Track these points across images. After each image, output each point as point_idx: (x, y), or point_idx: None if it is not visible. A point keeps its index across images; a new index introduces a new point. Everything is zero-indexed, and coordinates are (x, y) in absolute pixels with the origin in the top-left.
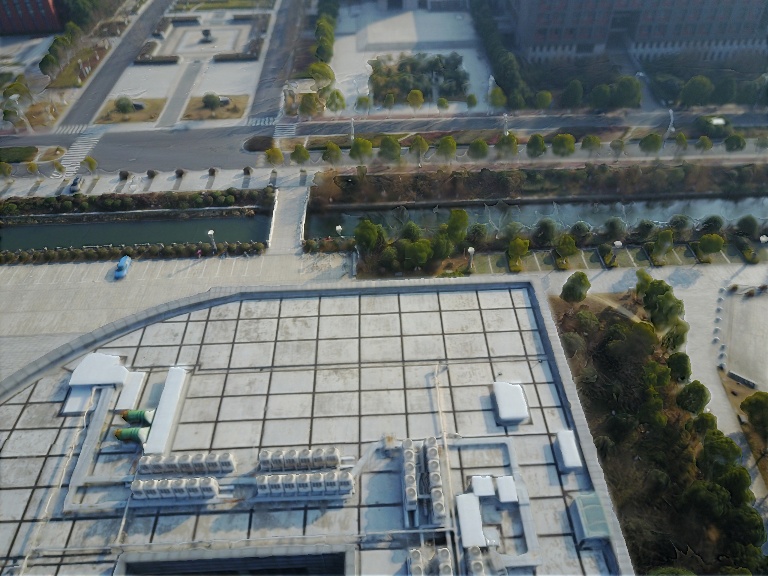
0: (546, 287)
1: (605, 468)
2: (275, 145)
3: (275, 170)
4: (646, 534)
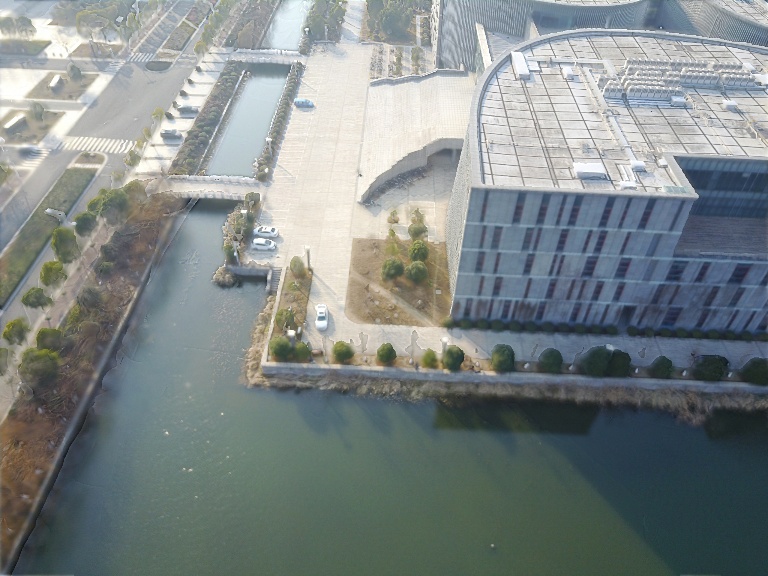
0: (358, 6)
1: None
2: (163, 61)
3: (203, 61)
4: None
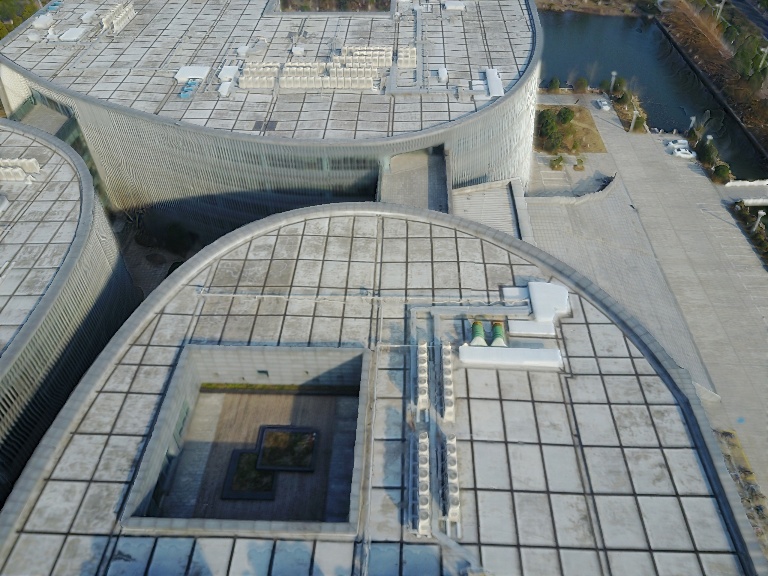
0: None
1: None
2: None
3: None
4: None
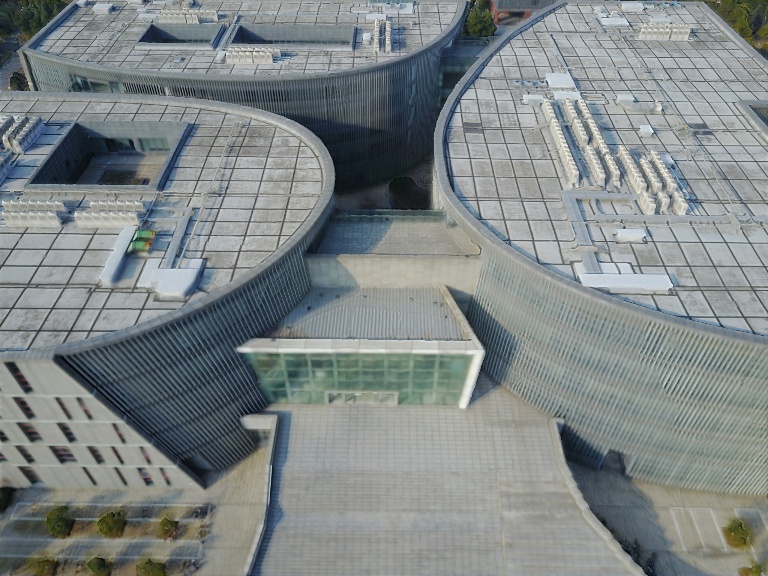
0: None
1: None
2: None
3: None
4: None
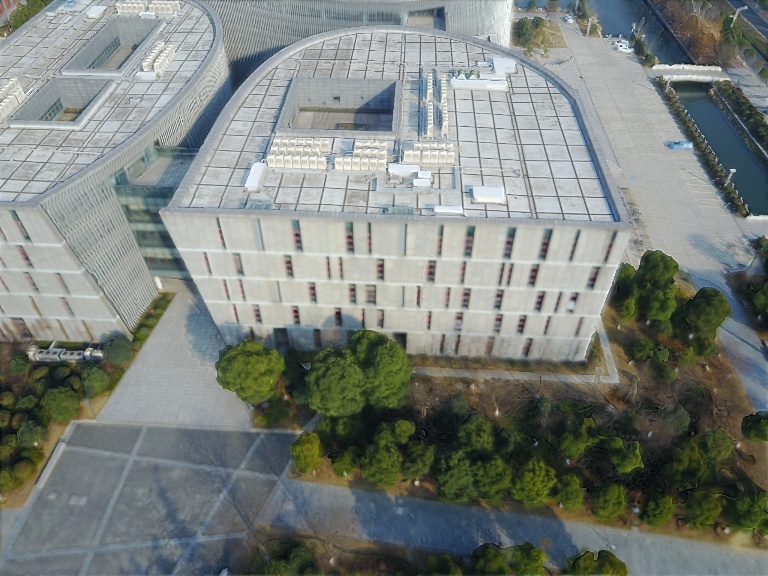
0: None
1: (522, 412)
2: None
3: None
4: (450, 396)
